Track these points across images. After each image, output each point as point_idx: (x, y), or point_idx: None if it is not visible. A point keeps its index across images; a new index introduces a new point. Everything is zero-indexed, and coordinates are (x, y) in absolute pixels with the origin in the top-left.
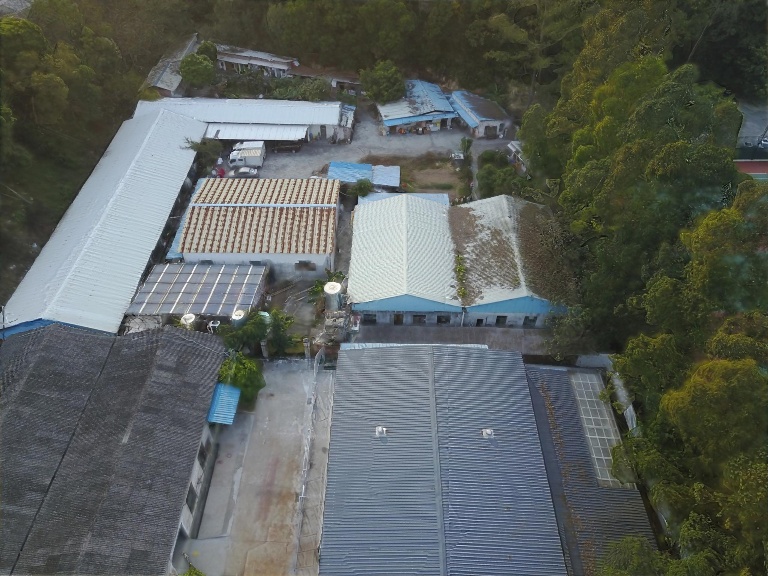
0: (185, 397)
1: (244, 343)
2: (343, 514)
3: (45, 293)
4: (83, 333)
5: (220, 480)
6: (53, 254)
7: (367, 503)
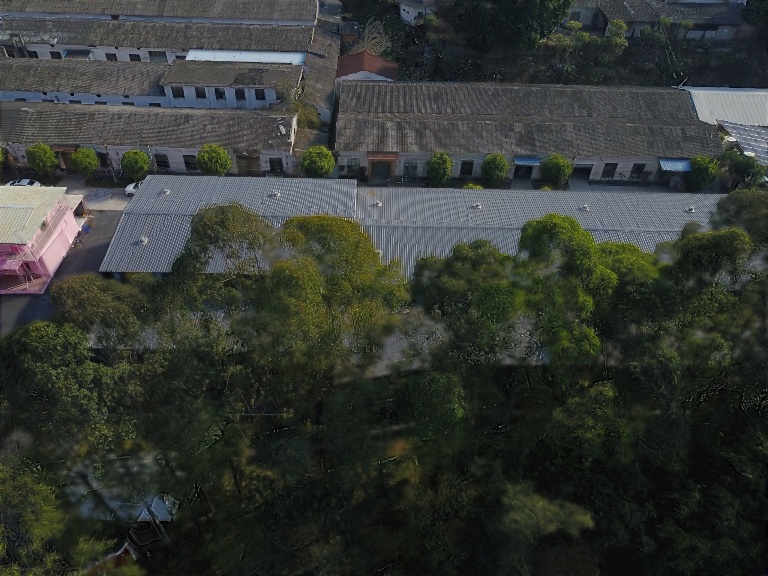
0: (669, 144)
1: (730, 169)
2: (624, 197)
3: (710, 90)
4: (689, 104)
5: (627, 189)
6: (745, 89)
7: (636, 205)
